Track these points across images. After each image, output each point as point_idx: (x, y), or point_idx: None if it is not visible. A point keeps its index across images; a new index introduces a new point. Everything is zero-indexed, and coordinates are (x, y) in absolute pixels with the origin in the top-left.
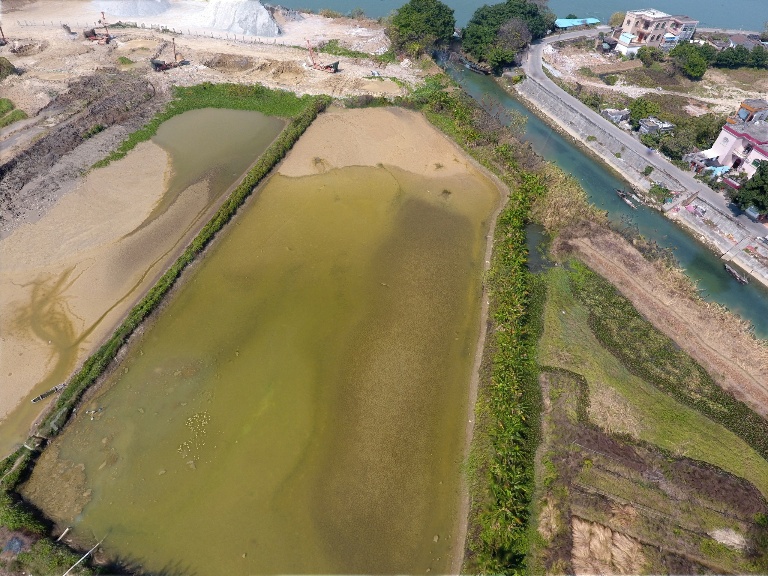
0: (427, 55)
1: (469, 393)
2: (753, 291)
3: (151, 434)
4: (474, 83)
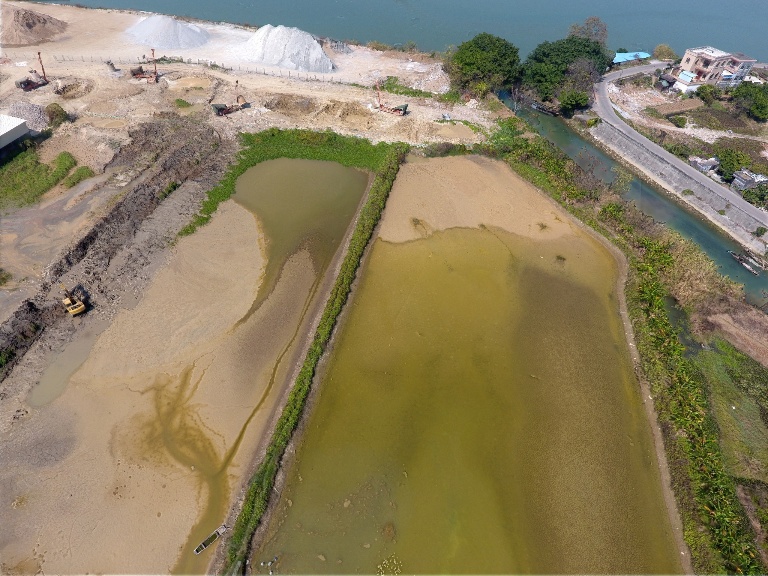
0: (493, 95)
1: (669, 515)
2: None
3: None
4: (545, 126)
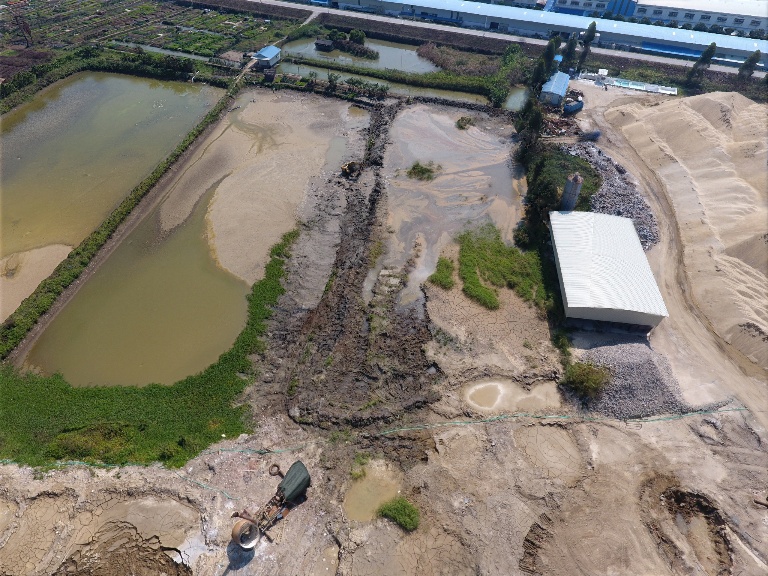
0: None
1: (6, 118)
2: None
3: (179, 102)
4: None
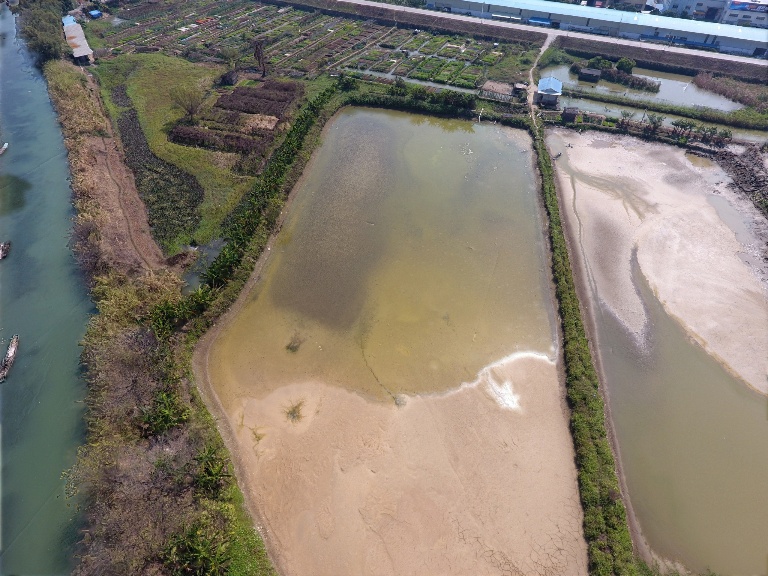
0: None
1: (311, 167)
2: (6, 239)
3: (487, 147)
4: None
